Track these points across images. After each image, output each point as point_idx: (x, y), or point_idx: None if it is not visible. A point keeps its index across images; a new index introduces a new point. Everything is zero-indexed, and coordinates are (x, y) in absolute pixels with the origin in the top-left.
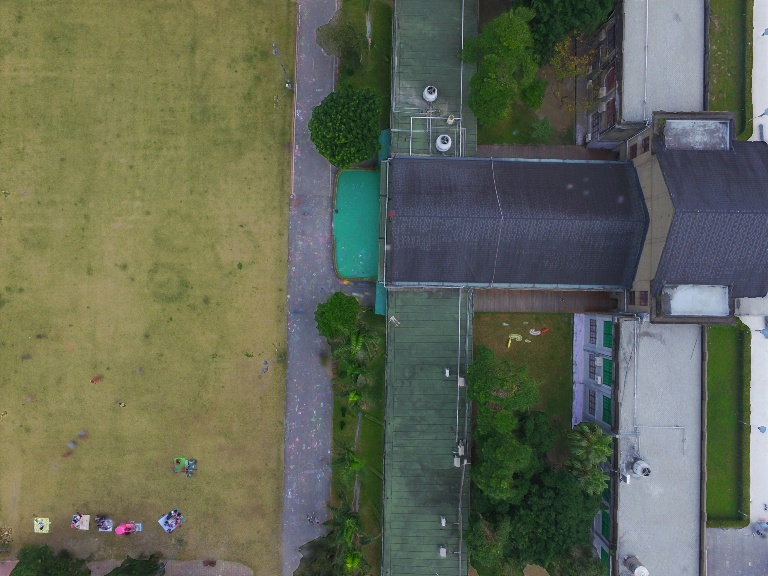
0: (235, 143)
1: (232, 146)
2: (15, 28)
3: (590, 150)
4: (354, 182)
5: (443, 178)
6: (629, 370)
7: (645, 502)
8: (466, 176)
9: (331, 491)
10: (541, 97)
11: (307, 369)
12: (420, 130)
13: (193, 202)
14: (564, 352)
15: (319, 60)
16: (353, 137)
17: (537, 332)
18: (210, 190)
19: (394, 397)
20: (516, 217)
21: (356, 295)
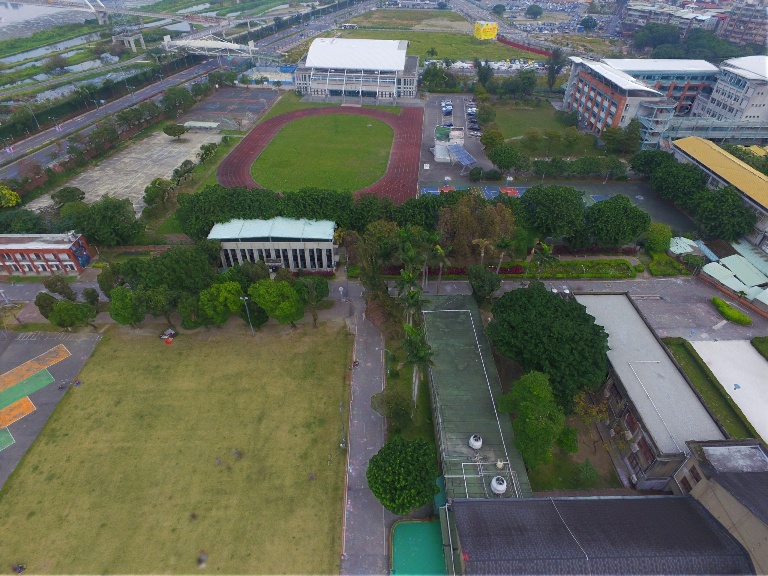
0: (287, 500)
1: (284, 503)
2: (111, 410)
3: (641, 492)
4: (411, 536)
5: (508, 519)
6: None
7: None
8: (531, 516)
9: None
10: (575, 442)
11: None
12: (472, 475)
13: (232, 569)
14: None
15: (369, 424)
16: (413, 479)
17: None
18: (253, 553)
19: None
20: (602, 556)
21: None
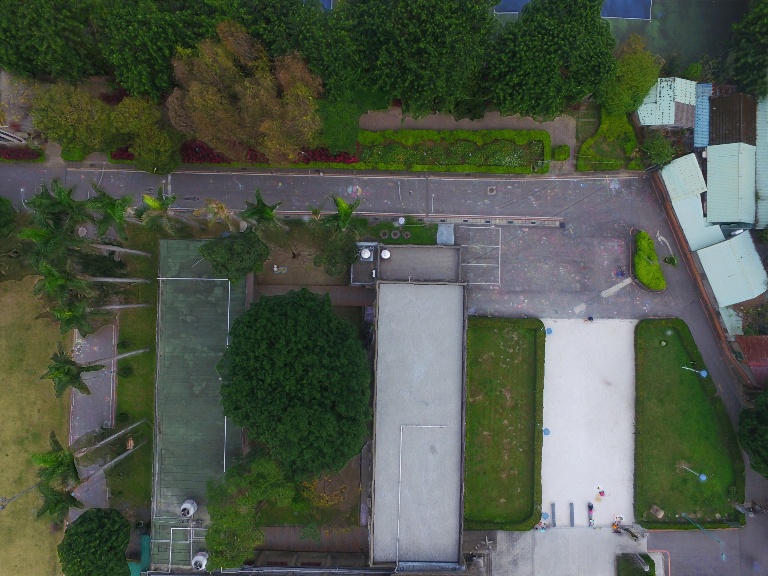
0: (5, 530)
1: (2, 533)
2: None
3: None
4: None
5: None
6: None
7: None
8: None
9: None
10: None
11: None
12: (181, 541)
13: None
14: None
15: None
16: None
17: None
18: None
19: None
20: None
21: None
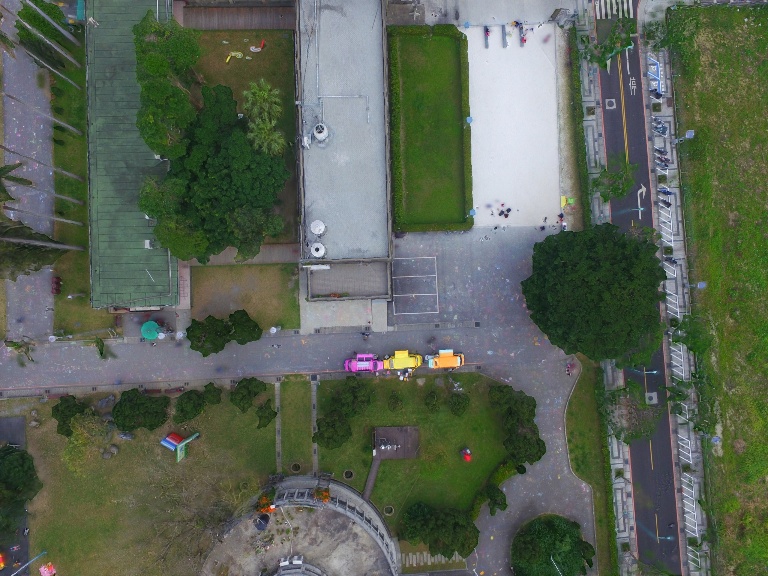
0: None
1: None
2: None
3: None
4: None
5: None
6: (311, 43)
7: (332, 171)
8: None
9: (54, 212)
10: None
11: (25, 91)
12: None
13: None
14: (286, 68)
15: None
16: None
17: (258, 49)
18: None
19: (96, 97)
20: None
21: (72, 17)
